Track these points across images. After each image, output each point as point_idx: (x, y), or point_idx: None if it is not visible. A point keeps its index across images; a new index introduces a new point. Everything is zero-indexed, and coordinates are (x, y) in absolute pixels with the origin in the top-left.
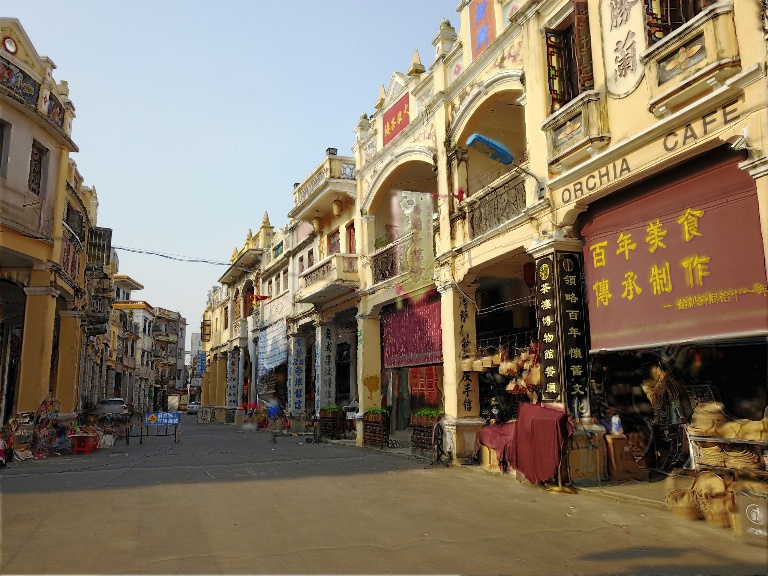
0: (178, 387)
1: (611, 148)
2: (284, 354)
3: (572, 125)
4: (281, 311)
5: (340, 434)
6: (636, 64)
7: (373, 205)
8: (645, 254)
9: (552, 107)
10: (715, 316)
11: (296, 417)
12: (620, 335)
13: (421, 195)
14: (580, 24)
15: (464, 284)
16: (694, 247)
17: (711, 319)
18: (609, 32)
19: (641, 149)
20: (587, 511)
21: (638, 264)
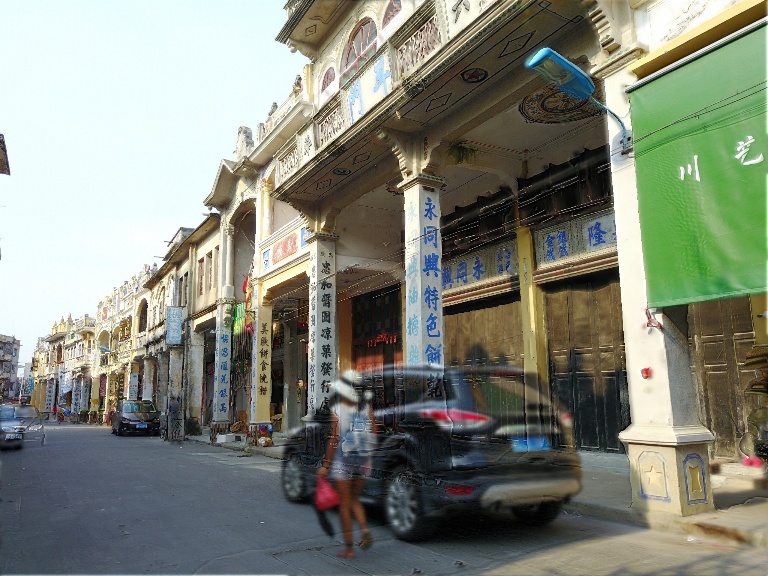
0: (11, 397)
1: None
2: (71, 387)
3: None
4: (72, 366)
5: (87, 420)
6: None
7: (99, 338)
8: None
9: (120, 340)
10: None
11: (74, 415)
12: None
13: (97, 351)
14: (124, 325)
15: (112, 375)
16: None
17: None
18: None
19: None
20: None
21: None
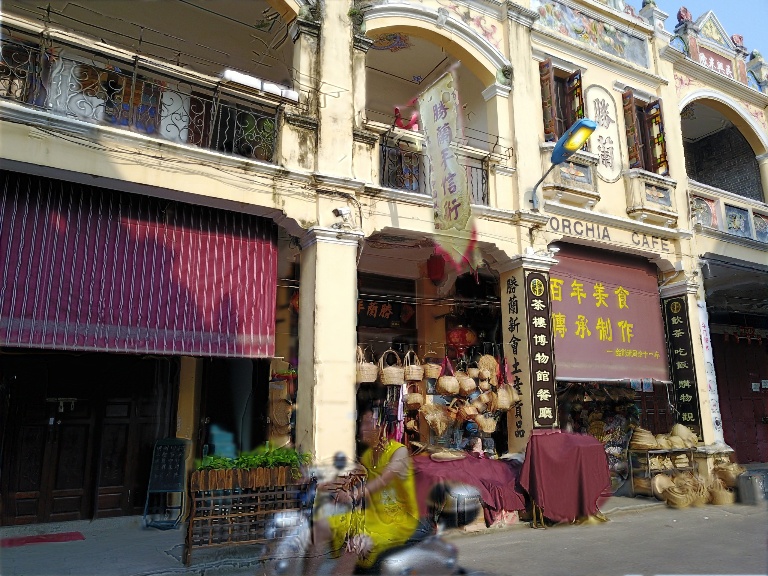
0: None
1: (610, 215)
2: None
3: (576, 169)
4: None
5: None
6: (613, 165)
7: None
8: (593, 305)
9: None
10: (637, 366)
11: None
12: (575, 367)
13: None
14: None
15: None
16: (625, 314)
17: (635, 367)
18: (594, 121)
19: (621, 230)
20: (724, 514)
21: (589, 311)
